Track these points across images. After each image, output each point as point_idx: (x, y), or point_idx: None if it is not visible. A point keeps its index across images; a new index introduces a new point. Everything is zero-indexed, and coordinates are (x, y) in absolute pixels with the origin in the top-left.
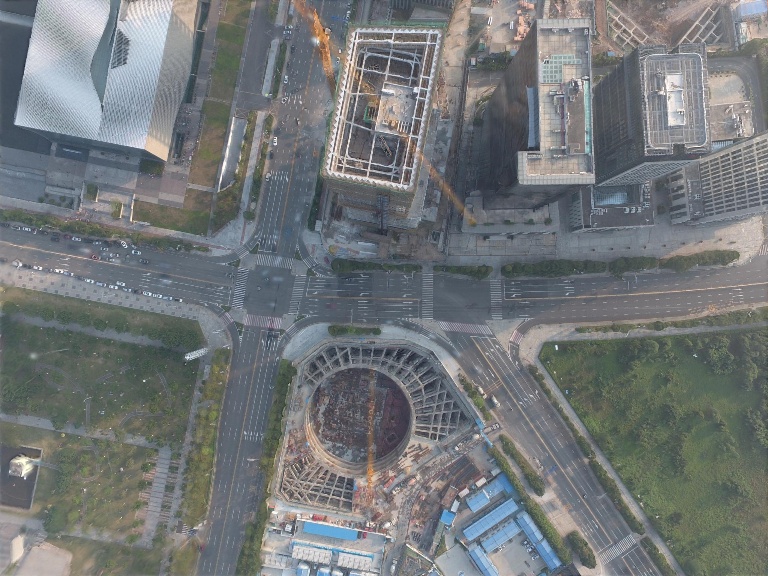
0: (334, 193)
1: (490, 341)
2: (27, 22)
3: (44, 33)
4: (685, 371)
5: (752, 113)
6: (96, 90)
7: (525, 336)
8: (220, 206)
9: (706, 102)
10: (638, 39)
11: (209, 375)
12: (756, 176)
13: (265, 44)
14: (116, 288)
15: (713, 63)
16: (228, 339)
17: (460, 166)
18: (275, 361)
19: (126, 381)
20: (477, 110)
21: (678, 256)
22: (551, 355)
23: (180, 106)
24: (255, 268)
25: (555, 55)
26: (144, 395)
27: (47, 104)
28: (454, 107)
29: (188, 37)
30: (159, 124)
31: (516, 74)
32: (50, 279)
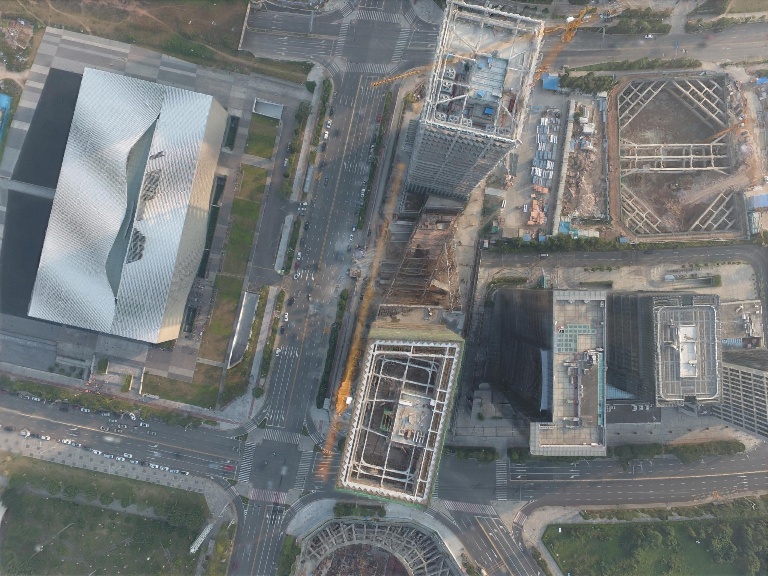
0: (343, 370)
1: (494, 521)
2: (43, 192)
3: (60, 226)
4: (687, 557)
5: (762, 301)
6: (110, 285)
7: (529, 518)
8: (229, 386)
9: (718, 354)
10: (651, 223)
11: (213, 550)
12: (765, 408)
13: (279, 219)
14: (123, 460)
15: (724, 250)
16: (233, 513)
17: (470, 347)
18: (279, 536)
19: (130, 553)
20: (488, 291)
21: (684, 446)
22: (554, 540)
23: (193, 282)
24: (262, 442)
25: (570, 324)
26: (148, 571)
27: (61, 296)
28: (465, 287)
29: (203, 218)
30: (172, 311)
31: (530, 309)
32: (58, 449)
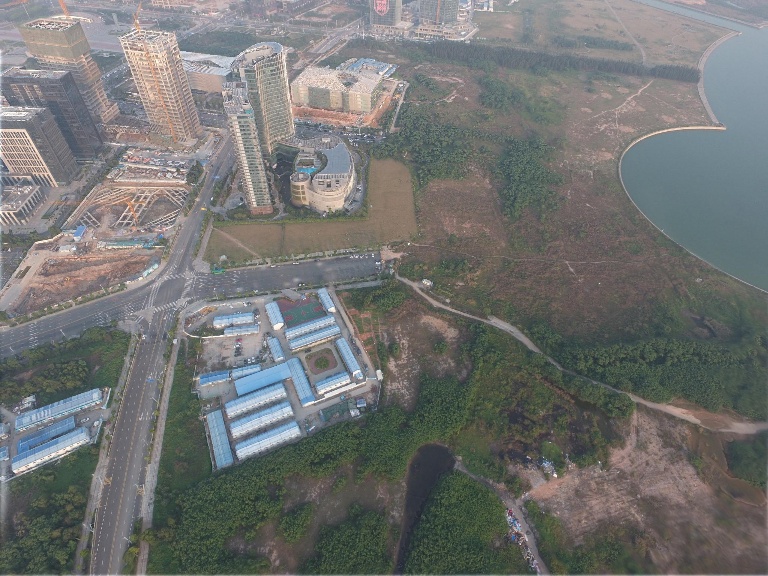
0: None
1: None
2: None
3: None
4: None
5: None
6: None
7: None
8: (116, 88)
9: None
10: None
11: None
12: None
13: None
14: None
15: None
16: None
17: None
18: None
19: None
20: None
21: None
22: None
23: None
24: None
25: None
26: None
27: None
28: None
29: None
30: None
31: None
32: None
